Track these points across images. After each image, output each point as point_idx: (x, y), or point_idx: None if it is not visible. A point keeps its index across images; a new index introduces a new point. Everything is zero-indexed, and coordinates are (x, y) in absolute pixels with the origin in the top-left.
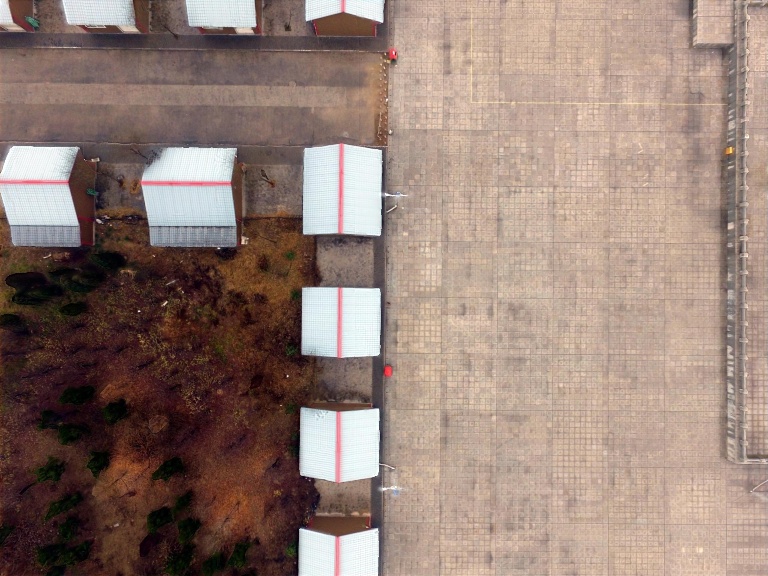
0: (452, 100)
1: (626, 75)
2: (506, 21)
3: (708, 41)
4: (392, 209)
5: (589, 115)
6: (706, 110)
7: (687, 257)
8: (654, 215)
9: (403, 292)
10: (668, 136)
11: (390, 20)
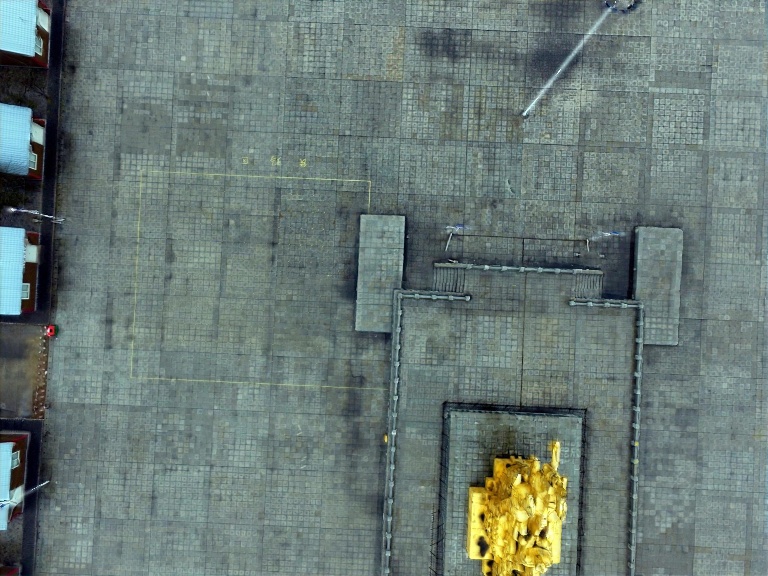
0: (112, 375)
1: (287, 356)
2: (170, 297)
3: (366, 329)
4: (45, 483)
5: (249, 395)
6: (367, 394)
7: (342, 543)
8: (310, 499)
9: (52, 568)
10: (328, 419)
11: (53, 292)
